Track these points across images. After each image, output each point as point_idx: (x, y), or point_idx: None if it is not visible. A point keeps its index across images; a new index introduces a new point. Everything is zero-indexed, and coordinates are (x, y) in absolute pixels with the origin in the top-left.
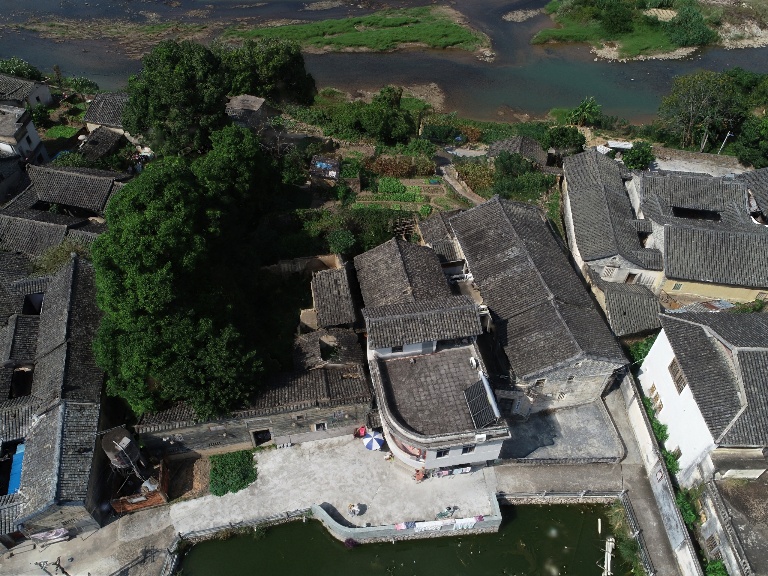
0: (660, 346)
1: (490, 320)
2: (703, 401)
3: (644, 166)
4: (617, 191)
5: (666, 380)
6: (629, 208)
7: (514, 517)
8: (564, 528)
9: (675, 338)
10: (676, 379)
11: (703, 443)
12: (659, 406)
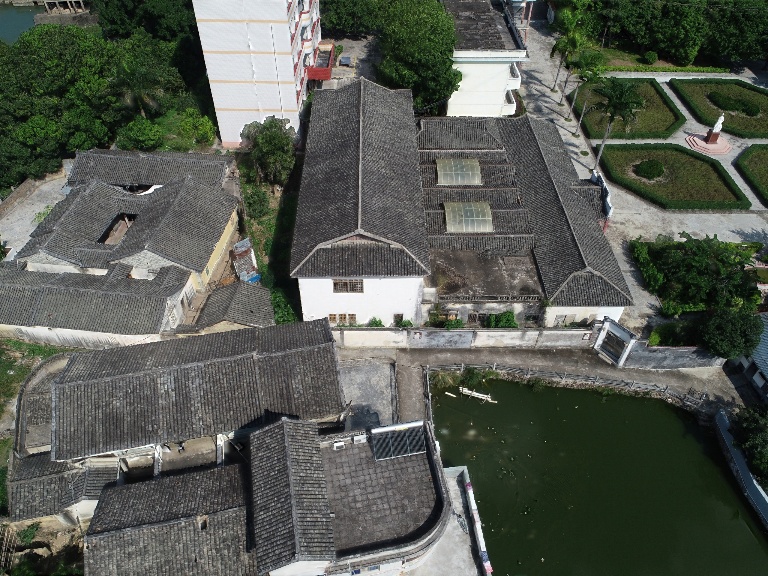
0: (310, 291)
1: (232, 441)
2: (392, 271)
3: (2, 250)
4: (51, 278)
5: (341, 300)
6: (86, 275)
7: (449, 462)
8: (455, 422)
9: (323, 271)
10: (349, 290)
11: (414, 289)
12: (350, 319)
